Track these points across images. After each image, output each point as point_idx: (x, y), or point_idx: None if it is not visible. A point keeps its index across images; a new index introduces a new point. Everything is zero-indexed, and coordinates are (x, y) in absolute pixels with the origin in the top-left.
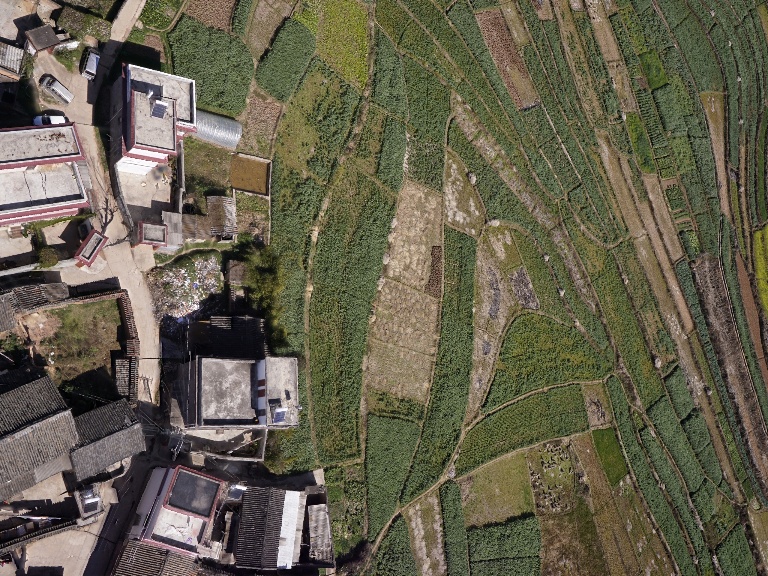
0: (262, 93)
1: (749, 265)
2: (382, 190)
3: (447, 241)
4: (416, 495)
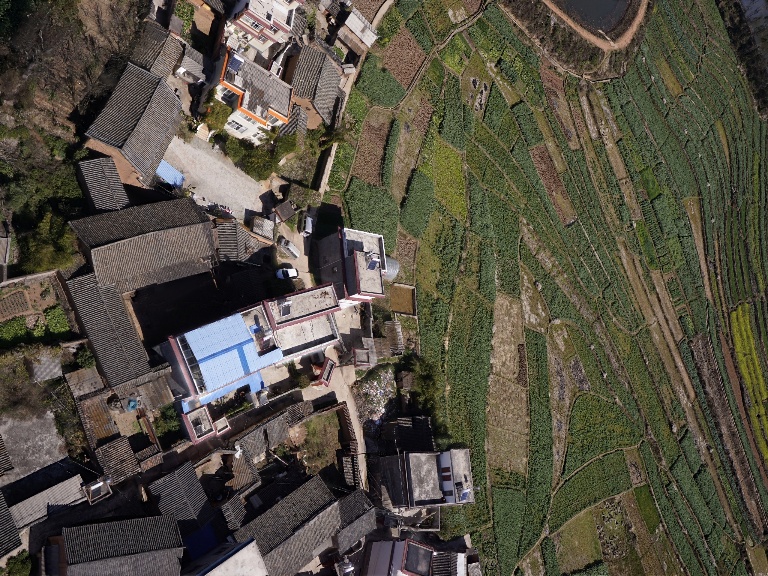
0: (404, 233)
1: (730, 341)
2: (483, 302)
3: (527, 340)
4: (527, 551)
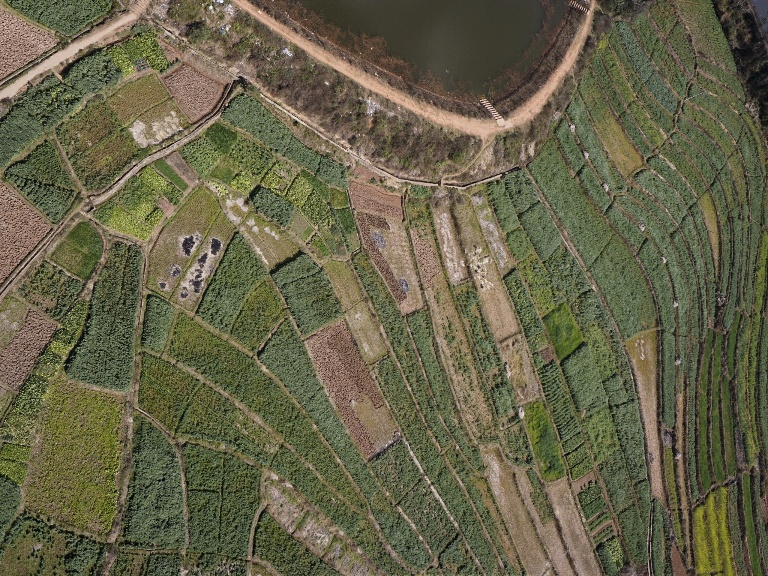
0: None
1: (688, 559)
2: None
3: None
4: None
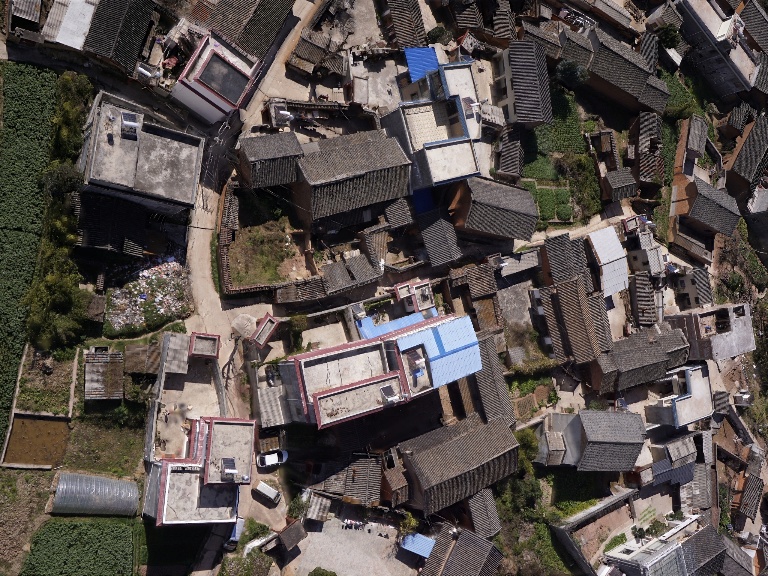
0: None
1: None
2: None
3: None
4: None
